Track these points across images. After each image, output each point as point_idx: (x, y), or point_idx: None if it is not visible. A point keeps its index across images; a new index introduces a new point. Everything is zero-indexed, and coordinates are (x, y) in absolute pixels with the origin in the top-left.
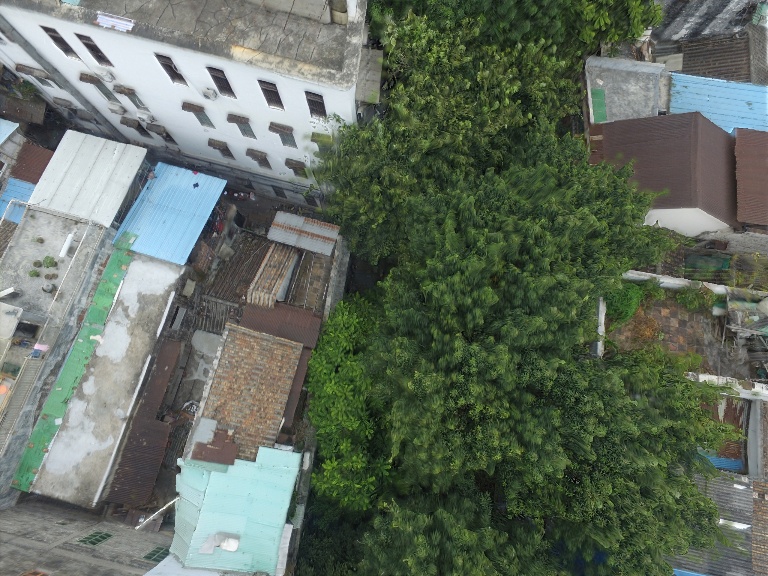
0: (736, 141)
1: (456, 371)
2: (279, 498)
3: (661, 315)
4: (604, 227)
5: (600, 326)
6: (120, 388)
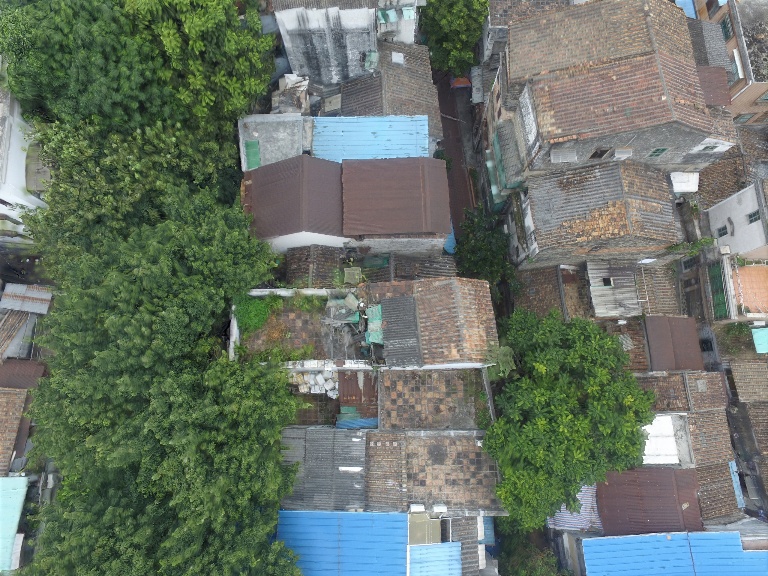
0: (343, 170)
1: (68, 398)
2: (10, 515)
3: (288, 319)
4: (198, 266)
5: (232, 337)
6: None
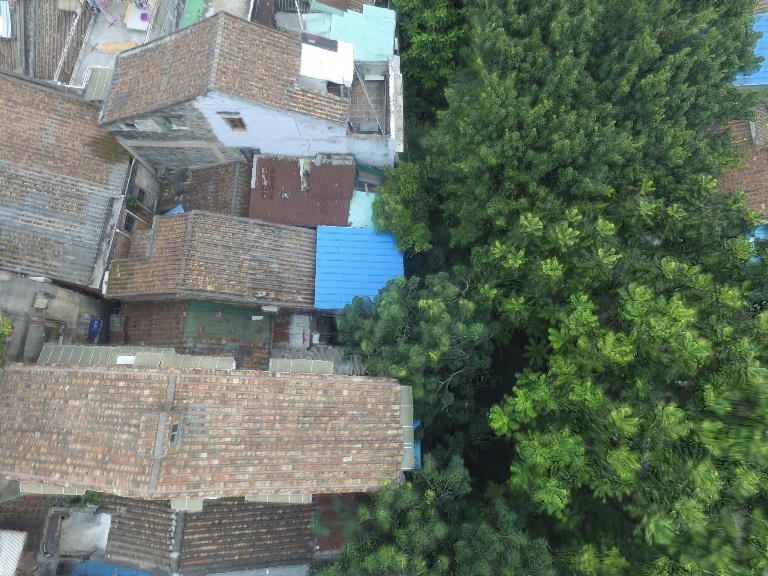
0: None
1: None
2: (385, 39)
3: None
4: None
5: None
6: (236, 12)
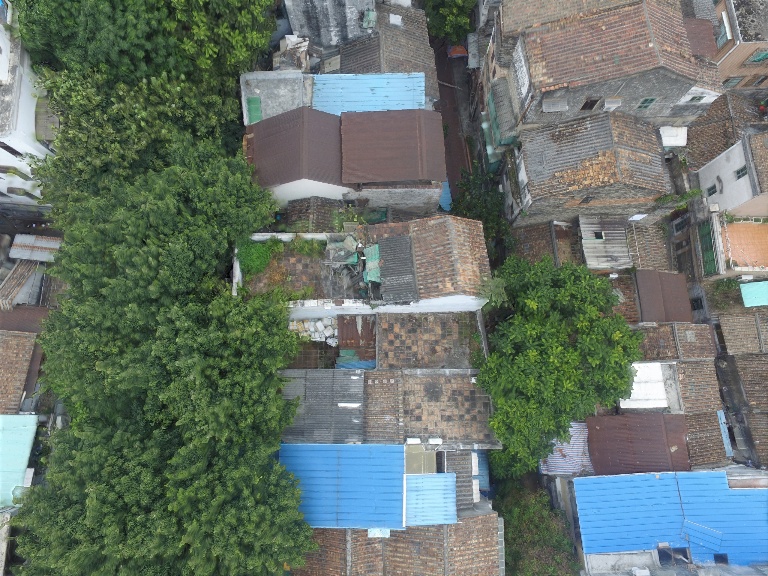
0: (342, 122)
1: (78, 326)
2: (21, 450)
3: (289, 263)
4: (202, 206)
5: (235, 279)
6: None
